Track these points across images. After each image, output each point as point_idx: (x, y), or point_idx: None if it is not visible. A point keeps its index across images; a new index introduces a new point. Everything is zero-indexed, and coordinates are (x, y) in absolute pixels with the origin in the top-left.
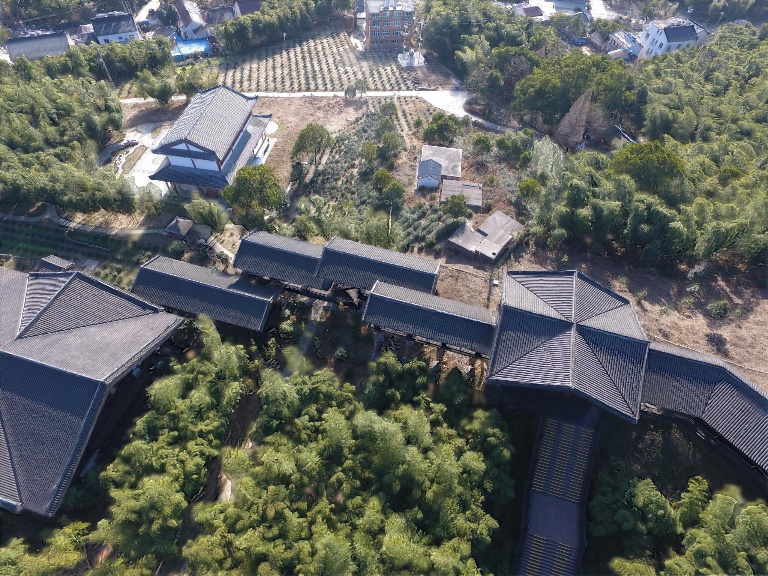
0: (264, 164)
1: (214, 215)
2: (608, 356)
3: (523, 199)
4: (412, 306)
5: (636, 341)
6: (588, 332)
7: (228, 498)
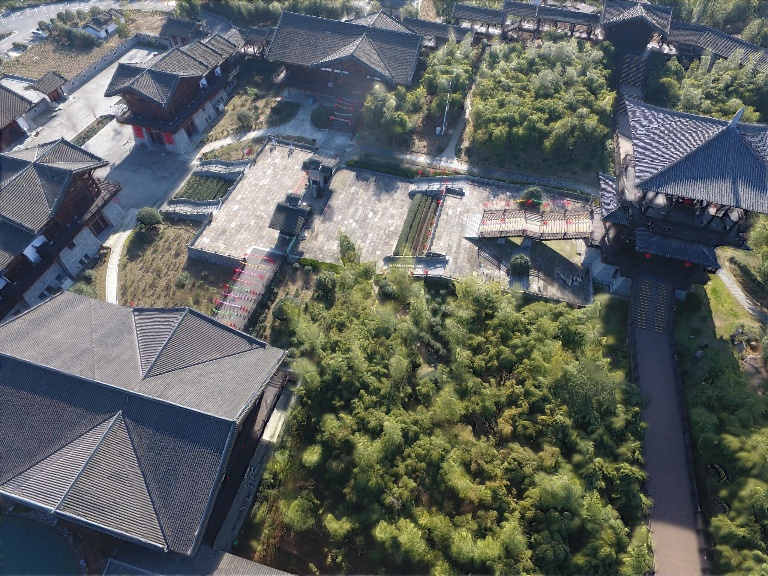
0: (420, 10)
1: (418, 13)
2: (655, 14)
3: (594, 4)
4: (559, 10)
5: (667, 8)
6: (645, 6)
7: (469, 107)
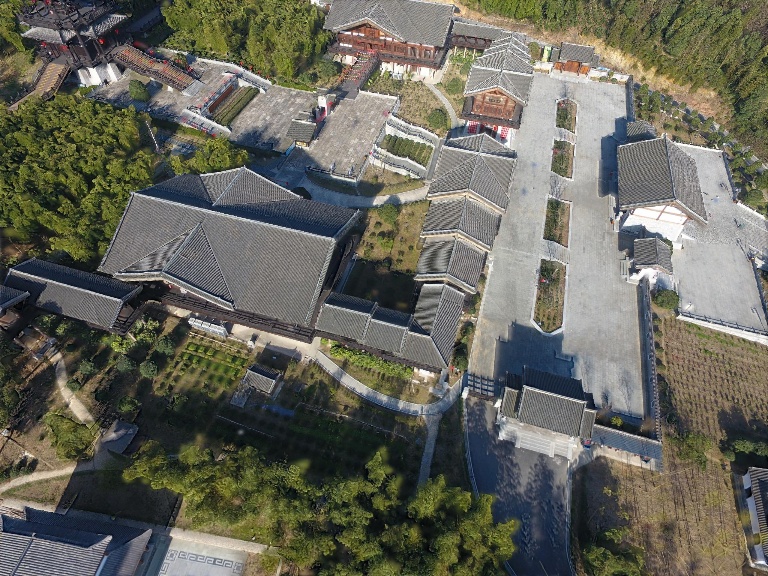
0: None
1: None
2: None
3: None
4: None
5: None
6: None
7: None
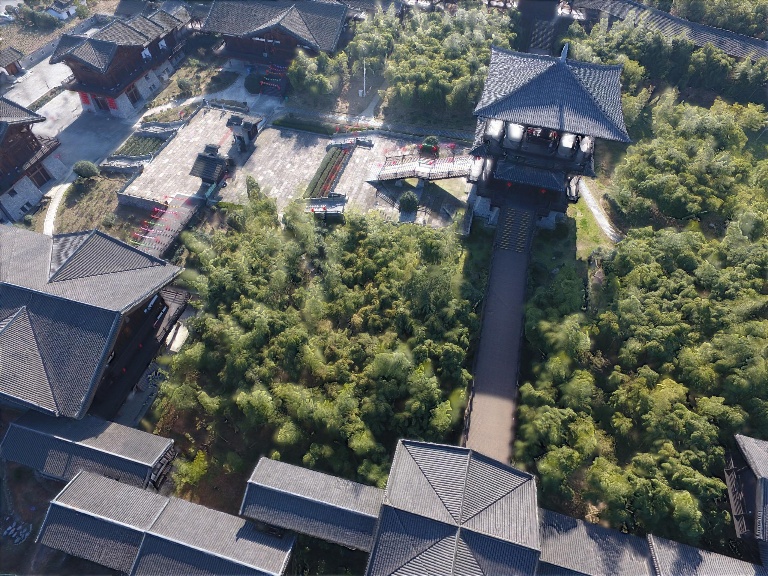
0: None
1: None
2: None
3: None
4: None
5: None
6: None
7: None
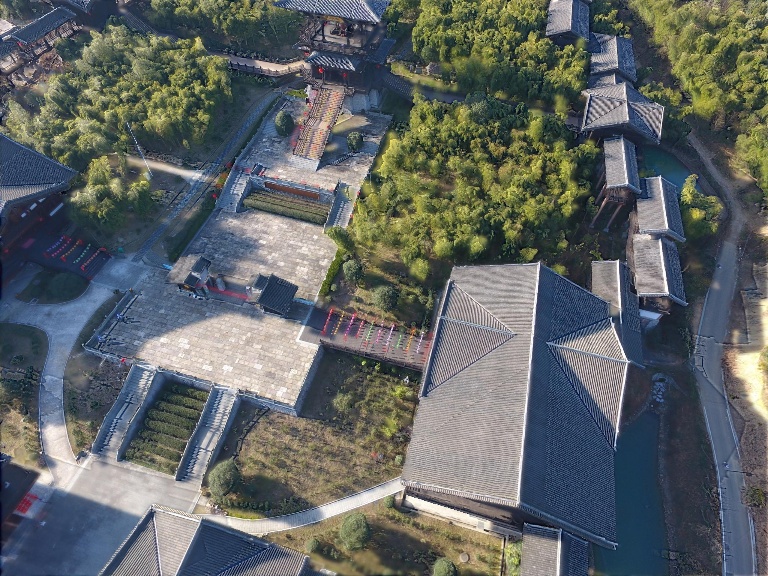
0: None
1: None
2: None
3: None
4: (30, 26)
5: None
6: None
7: None
